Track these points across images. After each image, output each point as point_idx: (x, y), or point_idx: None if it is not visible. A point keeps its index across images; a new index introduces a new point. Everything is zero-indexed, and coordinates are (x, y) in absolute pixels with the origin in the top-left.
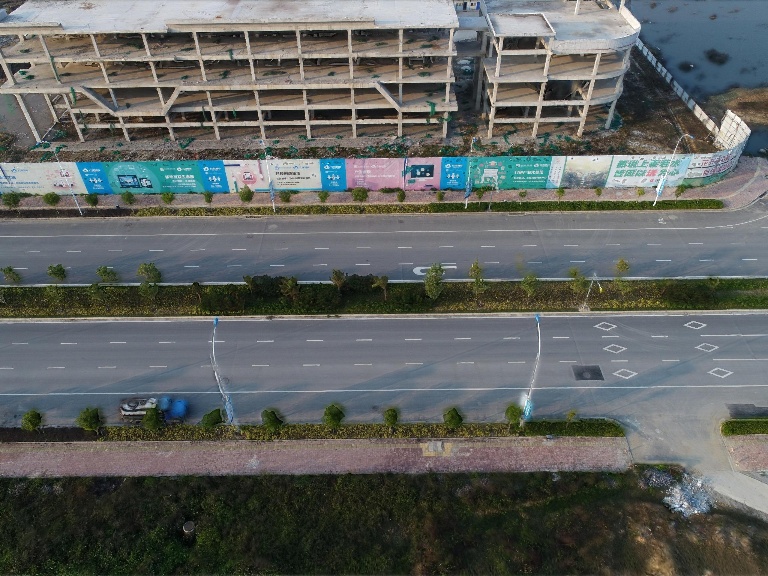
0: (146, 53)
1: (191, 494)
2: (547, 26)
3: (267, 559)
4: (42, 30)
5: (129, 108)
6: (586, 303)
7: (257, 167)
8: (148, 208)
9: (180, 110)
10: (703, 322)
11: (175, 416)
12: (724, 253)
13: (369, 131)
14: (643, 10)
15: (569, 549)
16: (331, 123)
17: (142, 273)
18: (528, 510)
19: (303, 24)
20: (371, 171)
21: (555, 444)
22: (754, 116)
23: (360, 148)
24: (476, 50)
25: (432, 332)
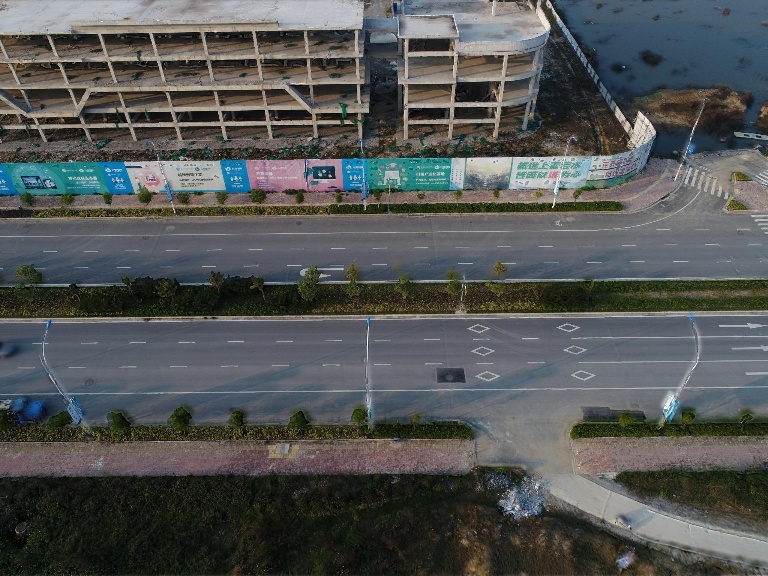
0: (55, 54)
1: (28, 495)
2: (454, 28)
3: (89, 560)
4: None
5: (43, 109)
6: (463, 305)
7: (159, 168)
8: (50, 209)
9: (94, 111)
10: (576, 325)
11: (29, 417)
12: (613, 255)
13: (287, 132)
14: (588, 11)
15: (389, 551)
16: (246, 124)
17: (20, 274)
18: (361, 512)
19: (207, 26)
20: (273, 173)
21: (402, 446)
22: (674, 117)
23: (274, 149)
24: (393, 51)
25: (305, 334)
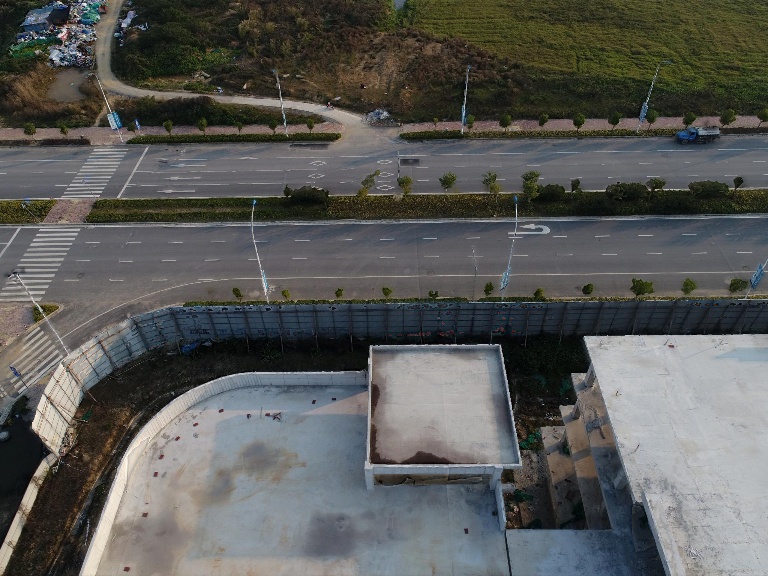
0: None
1: None
2: (377, 392)
3: None
4: None
5: None
6: None
7: None
8: None
9: None
10: None
11: None
12: (236, 249)
13: None
14: None
15: None
16: None
17: None
18: None
19: None
20: None
21: None
22: None
23: None
24: None
25: None
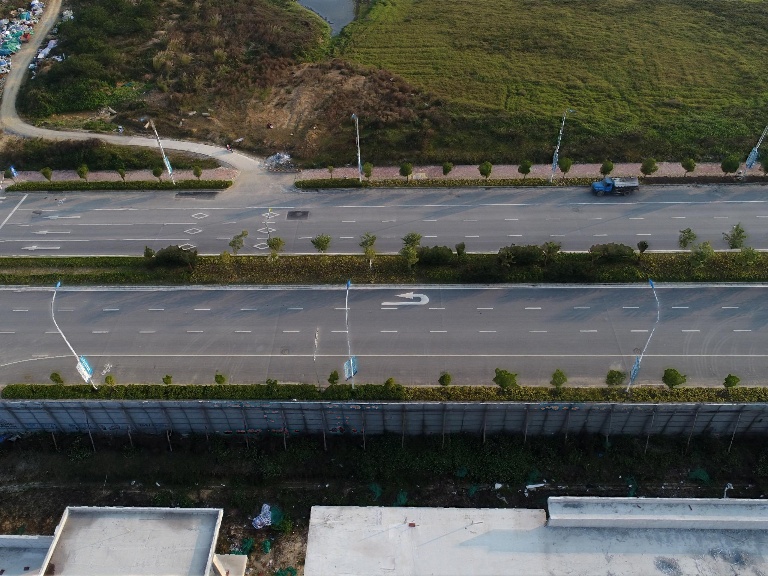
0: None
1: None
2: None
3: None
4: None
5: None
6: None
7: None
8: None
9: None
10: None
11: None
12: (83, 319)
13: None
14: None
15: None
16: None
17: None
18: None
19: None
20: None
21: None
22: None
23: None
24: None
25: None
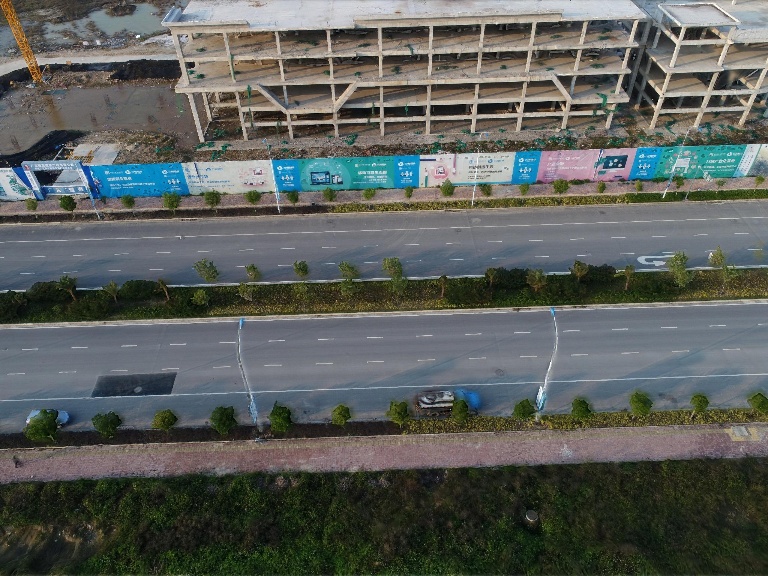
0: (325, 50)
1: (524, 484)
2: (726, 16)
3: (629, 545)
4: (228, 28)
5: (300, 105)
6: None
7: (452, 161)
8: (343, 204)
9: (350, 106)
10: None
11: (472, 408)
12: None
13: (530, 124)
14: None
15: None
16: (498, 117)
17: (389, 268)
18: None
19: (490, 18)
20: (564, 163)
21: None
22: None
23: (528, 141)
24: (636, 41)
25: (685, 320)
